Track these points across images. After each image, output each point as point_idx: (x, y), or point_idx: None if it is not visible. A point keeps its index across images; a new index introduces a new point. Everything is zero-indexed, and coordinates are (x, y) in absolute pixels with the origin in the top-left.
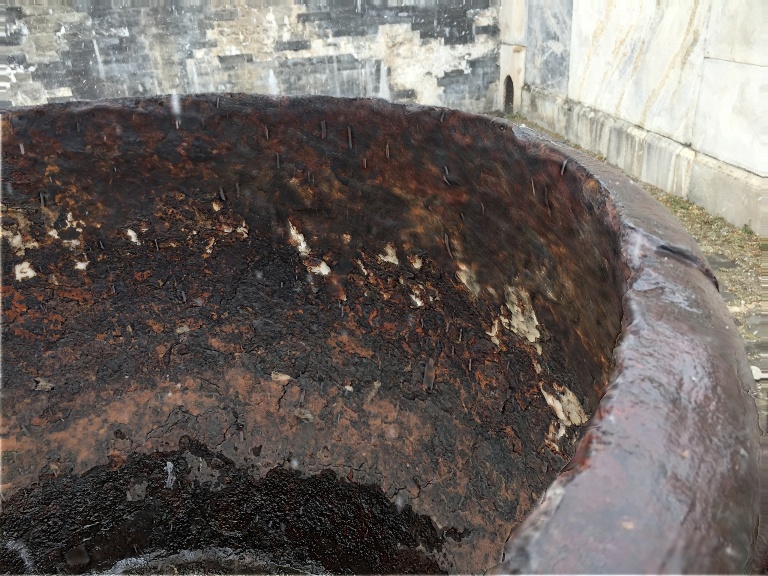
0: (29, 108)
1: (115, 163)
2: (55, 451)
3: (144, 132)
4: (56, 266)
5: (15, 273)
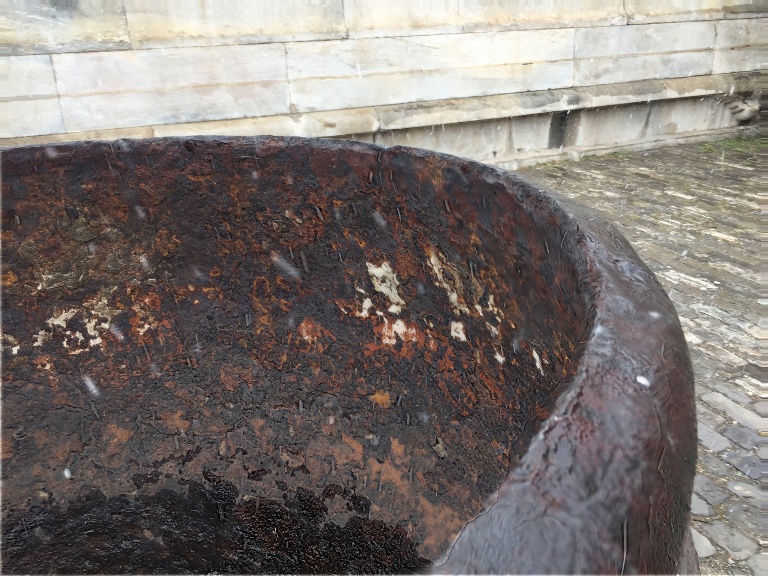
0: (459, 162)
1: (517, 262)
2: (418, 515)
3: (526, 239)
4: (481, 343)
5: (451, 328)
